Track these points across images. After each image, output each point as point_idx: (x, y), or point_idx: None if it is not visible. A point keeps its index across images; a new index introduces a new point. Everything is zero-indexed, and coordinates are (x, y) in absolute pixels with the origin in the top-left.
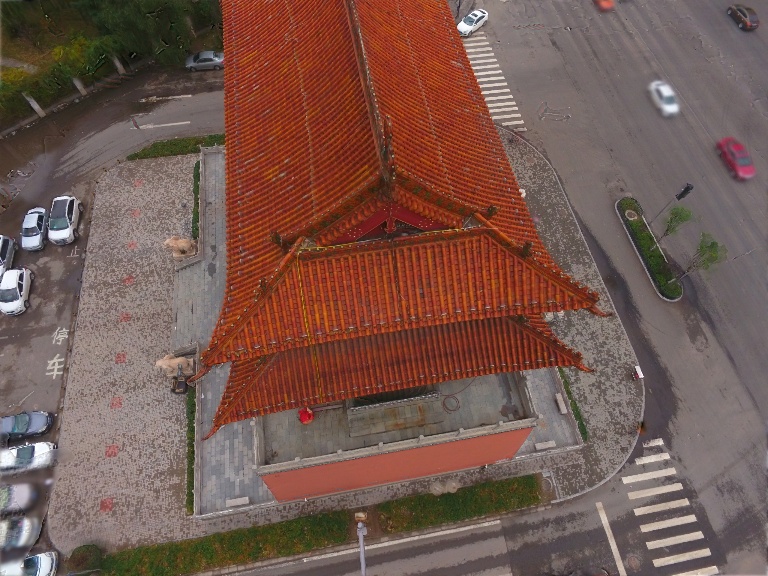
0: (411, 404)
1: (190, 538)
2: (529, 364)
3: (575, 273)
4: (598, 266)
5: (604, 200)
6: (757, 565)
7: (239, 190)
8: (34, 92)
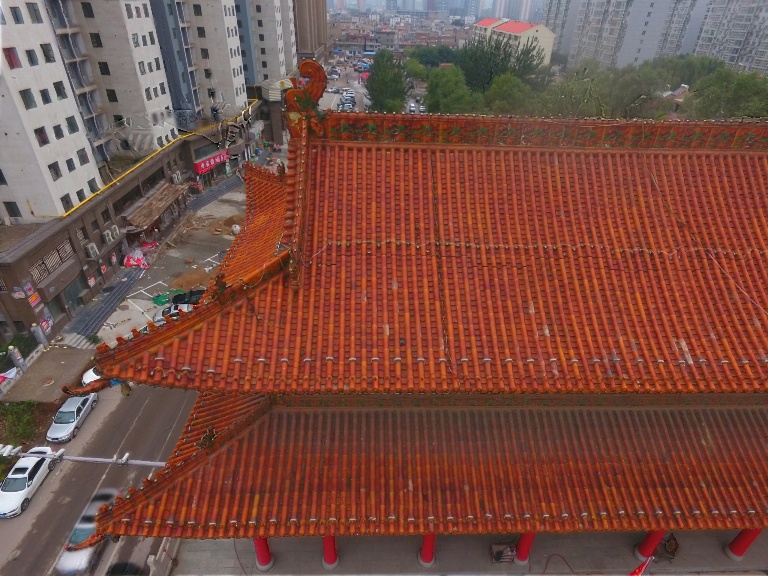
0: None
1: None
2: None
3: None
4: None
5: None
6: None
7: None
8: None
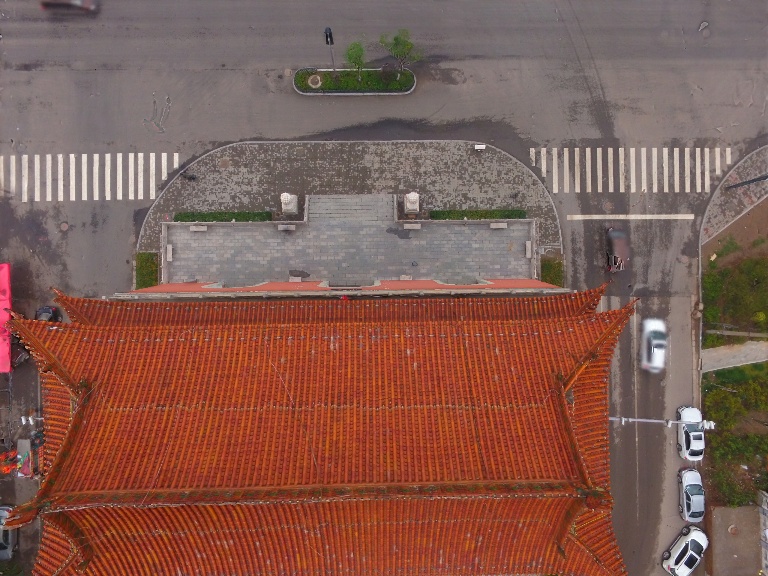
0: None
1: None
2: None
3: (373, 165)
4: (368, 139)
5: (290, 102)
6: (624, 118)
7: (469, 568)
8: None
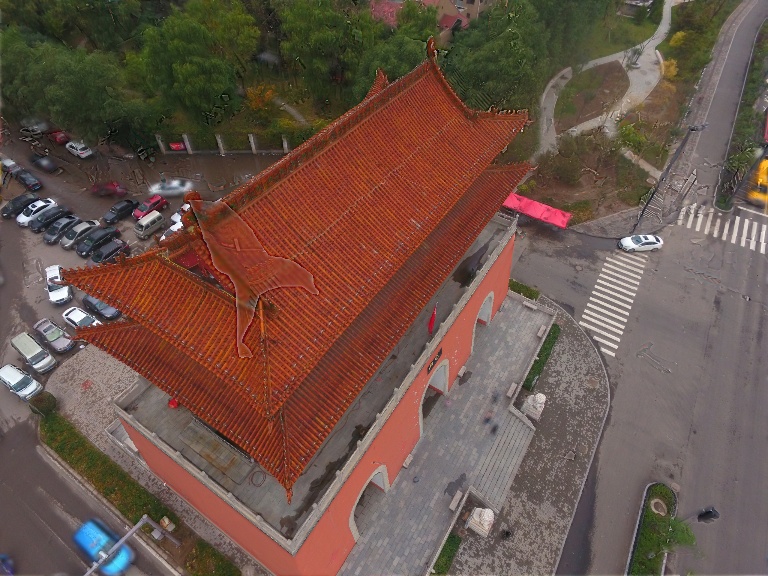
0: (231, 451)
1: (95, 444)
2: (267, 462)
3: (542, 511)
4: (573, 524)
5: (641, 471)
6: None
7: None
8: (288, 137)
